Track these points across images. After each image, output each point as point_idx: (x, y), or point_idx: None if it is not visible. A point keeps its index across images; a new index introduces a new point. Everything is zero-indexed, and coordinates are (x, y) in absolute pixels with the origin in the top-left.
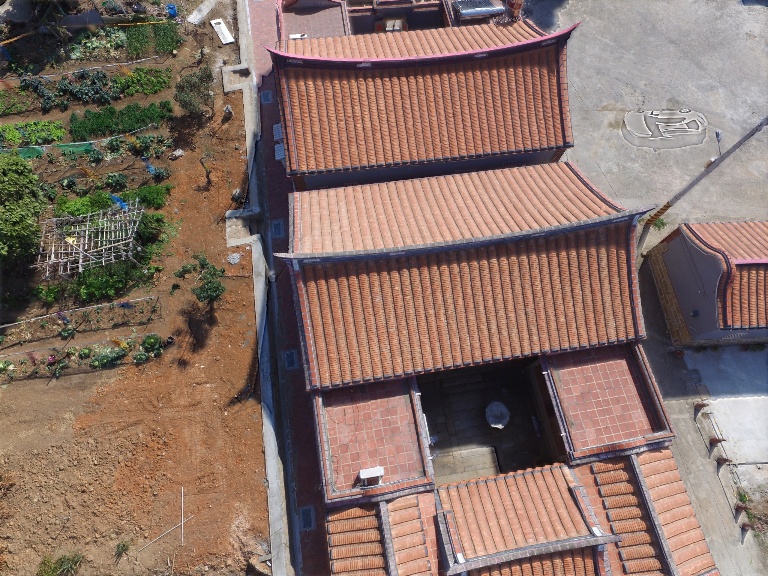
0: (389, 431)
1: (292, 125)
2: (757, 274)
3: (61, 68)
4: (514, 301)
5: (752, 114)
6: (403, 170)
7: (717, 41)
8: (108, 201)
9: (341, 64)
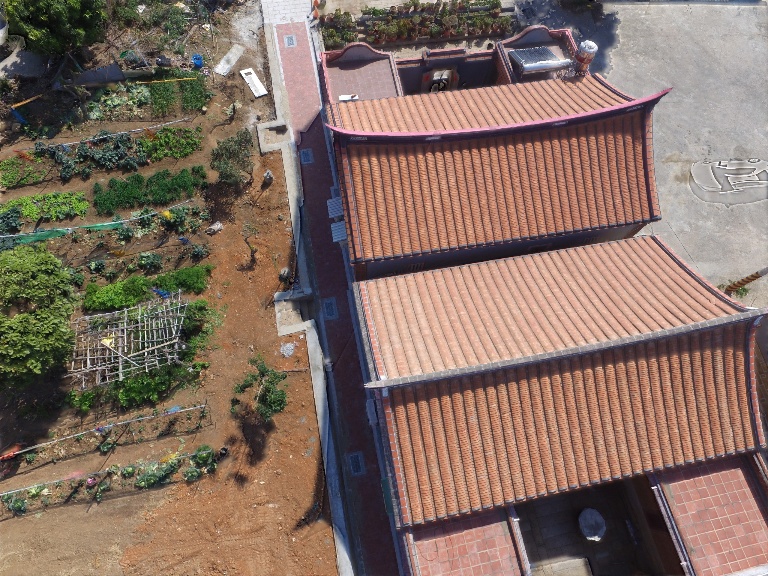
0: (489, 568)
1: (355, 207)
2: None
3: (79, 130)
4: (622, 412)
5: None
6: (475, 250)
7: None
8: (143, 287)
9: (409, 138)
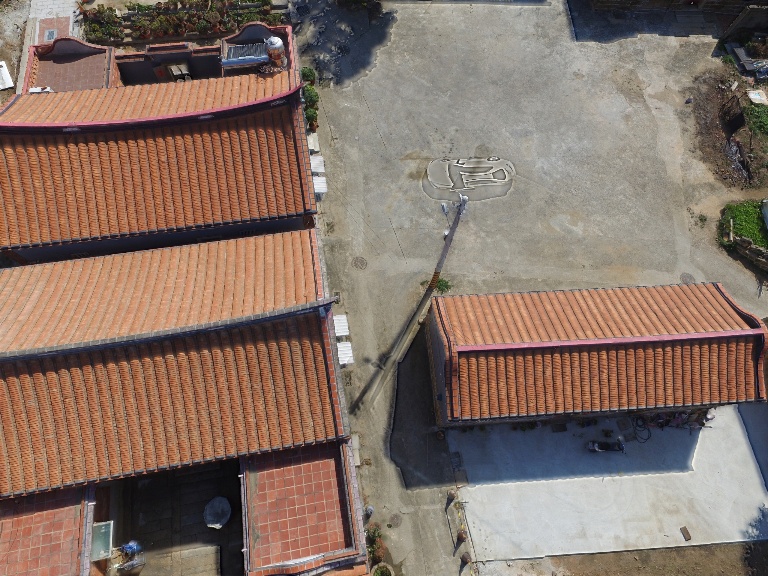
0: (47, 549)
1: None
2: (487, 360)
3: None
4: (195, 400)
5: (565, 162)
6: (130, 240)
7: (541, 81)
8: None
9: (43, 129)
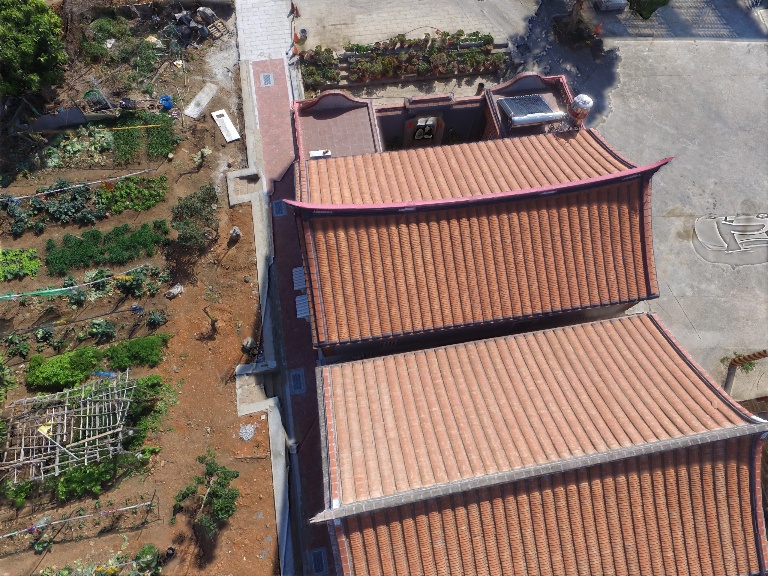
0: None
1: (319, 285)
2: None
3: (36, 178)
4: (610, 533)
5: None
6: (453, 329)
7: None
8: (92, 360)
9: (379, 210)
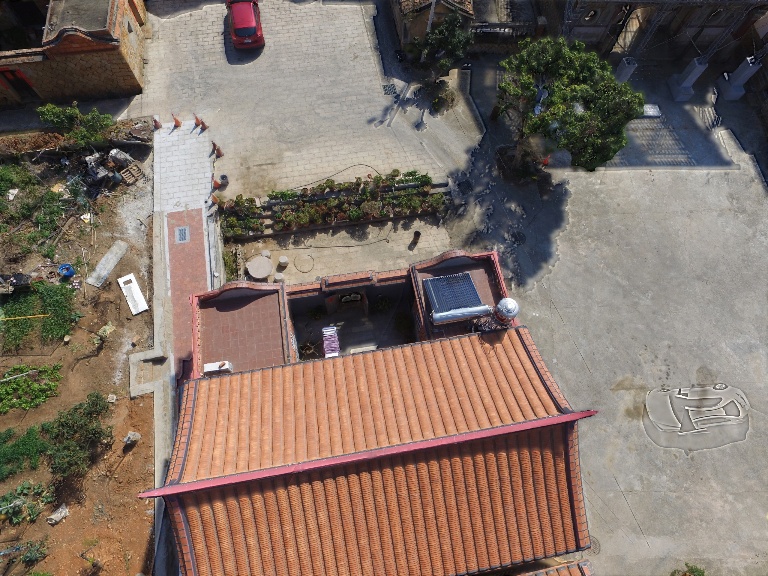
0: None
1: (195, 563)
2: None
3: None
4: None
5: None
6: None
7: (752, 274)
8: None
9: None
